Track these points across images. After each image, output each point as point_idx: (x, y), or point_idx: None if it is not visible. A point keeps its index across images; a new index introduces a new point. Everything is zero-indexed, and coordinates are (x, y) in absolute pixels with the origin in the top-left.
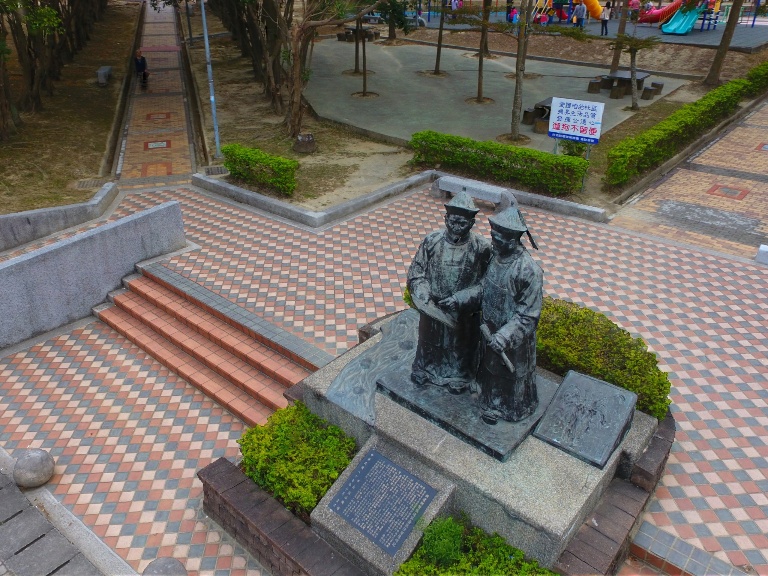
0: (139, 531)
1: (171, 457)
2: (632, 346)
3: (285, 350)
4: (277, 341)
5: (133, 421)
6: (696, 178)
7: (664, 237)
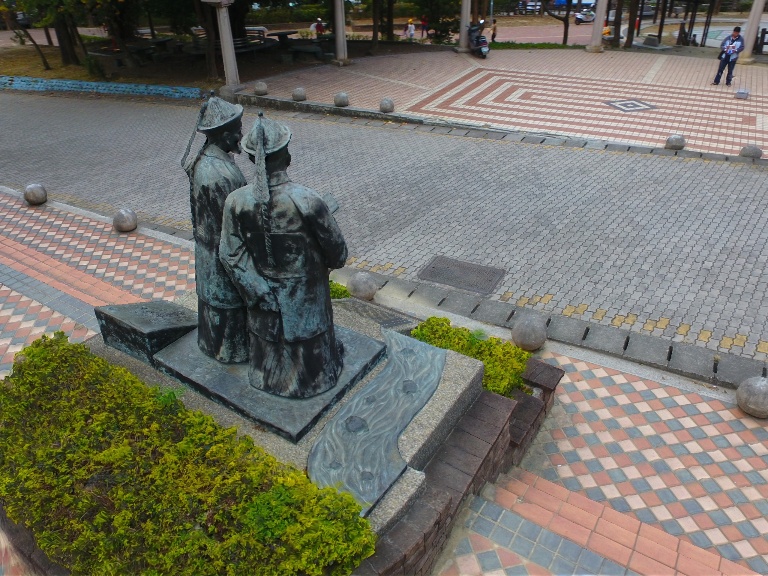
0: (597, 380)
1: (646, 452)
2: (14, 397)
3: None
4: (631, 572)
5: (756, 497)
6: None
7: None
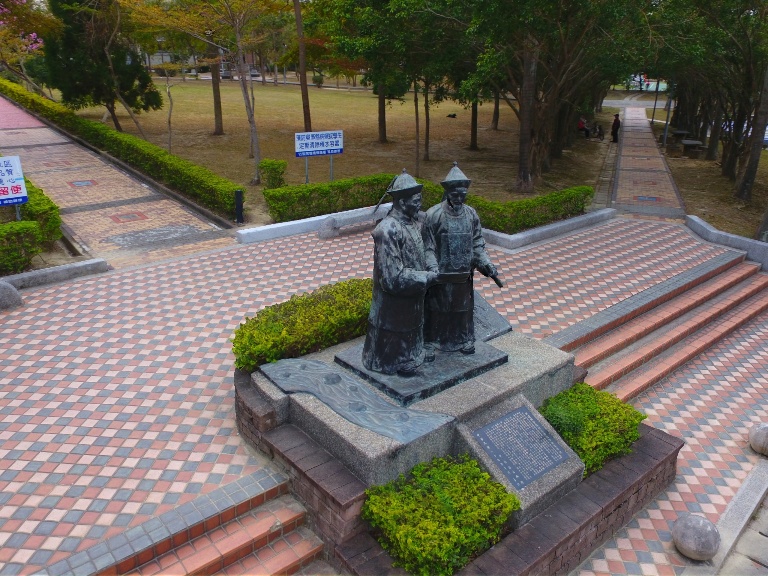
0: None
1: None
2: None
3: (193, 529)
4: (168, 534)
5: None
6: (85, 217)
7: (172, 257)
